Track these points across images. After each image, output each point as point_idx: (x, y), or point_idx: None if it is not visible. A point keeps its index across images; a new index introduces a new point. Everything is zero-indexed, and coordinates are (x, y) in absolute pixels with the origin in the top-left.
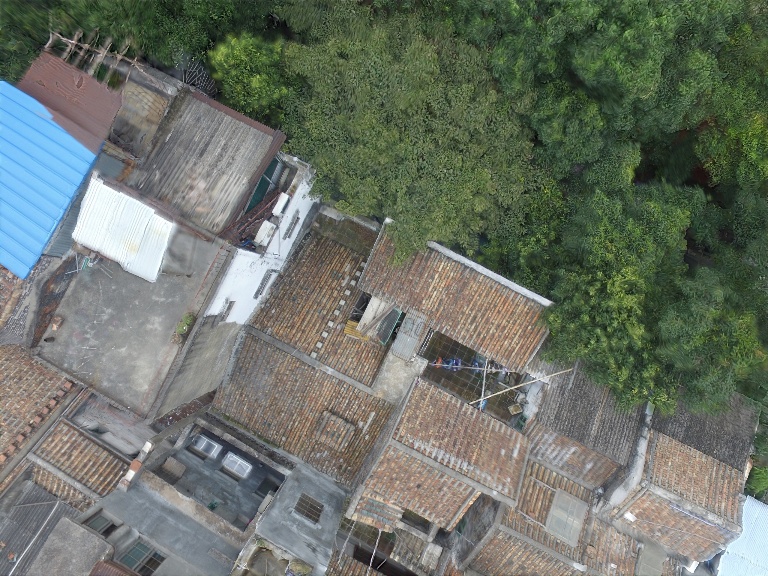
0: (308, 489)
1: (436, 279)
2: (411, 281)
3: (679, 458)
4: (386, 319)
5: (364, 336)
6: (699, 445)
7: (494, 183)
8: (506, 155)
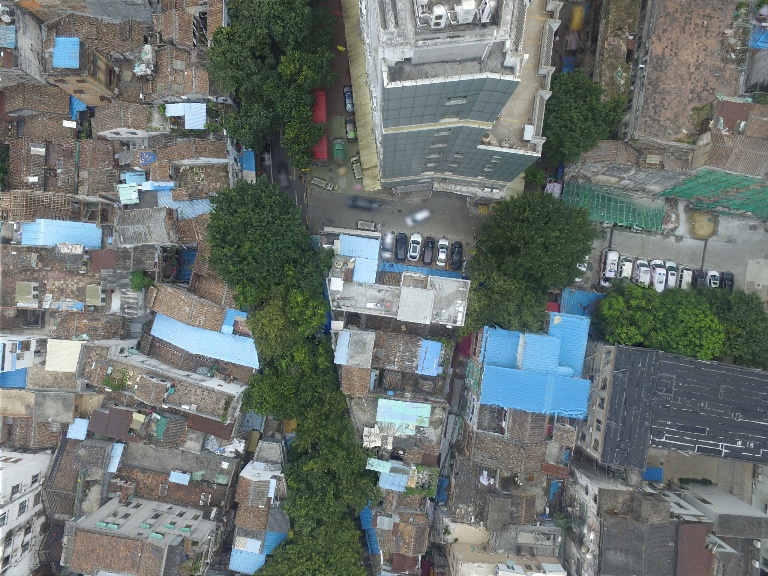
0: (154, 5)
1: (218, 6)
2: (215, 1)
3: (204, 77)
4: (204, 3)
5: (198, 1)
6: (211, 84)
7: (245, 7)
8: (255, 8)
